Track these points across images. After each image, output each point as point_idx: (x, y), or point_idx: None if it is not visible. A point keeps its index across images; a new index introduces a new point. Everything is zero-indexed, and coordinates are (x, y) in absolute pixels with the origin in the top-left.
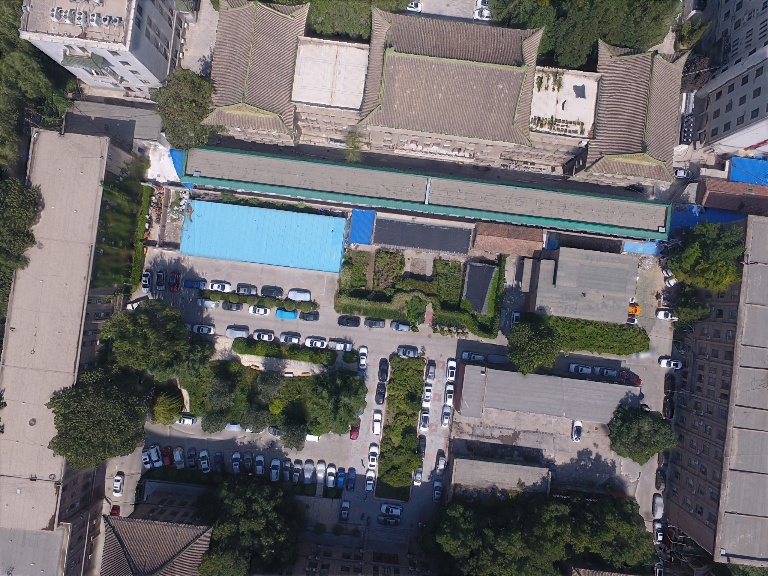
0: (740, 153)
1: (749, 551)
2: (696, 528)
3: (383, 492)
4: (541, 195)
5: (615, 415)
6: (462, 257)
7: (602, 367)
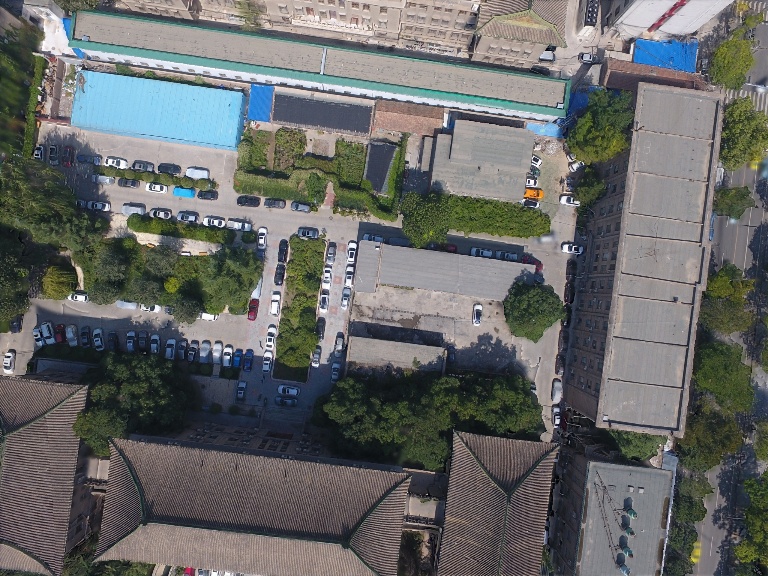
0: (644, 35)
1: (631, 418)
2: (585, 402)
3: (281, 373)
4: (439, 69)
5: (510, 292)
6: (365, 139)
7: (503, 251)
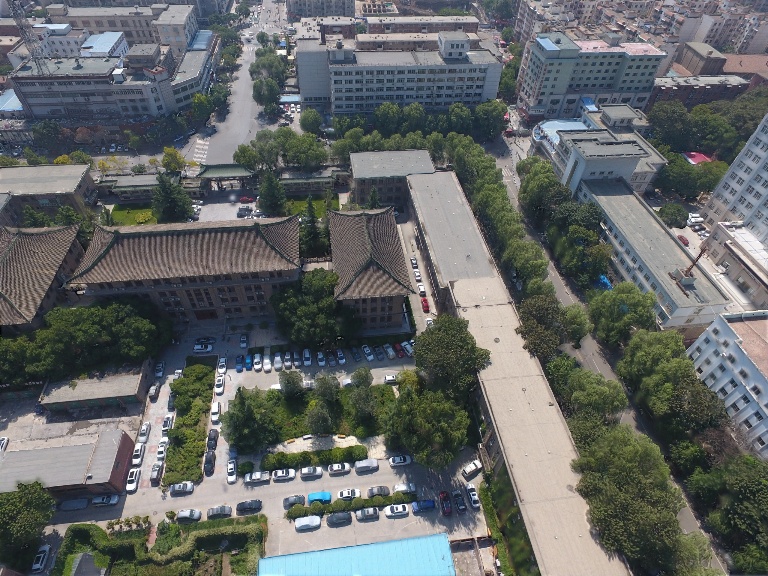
0: None
1: None
2: None
3: (211, 360)
4: None
5: None
6: None
7: None
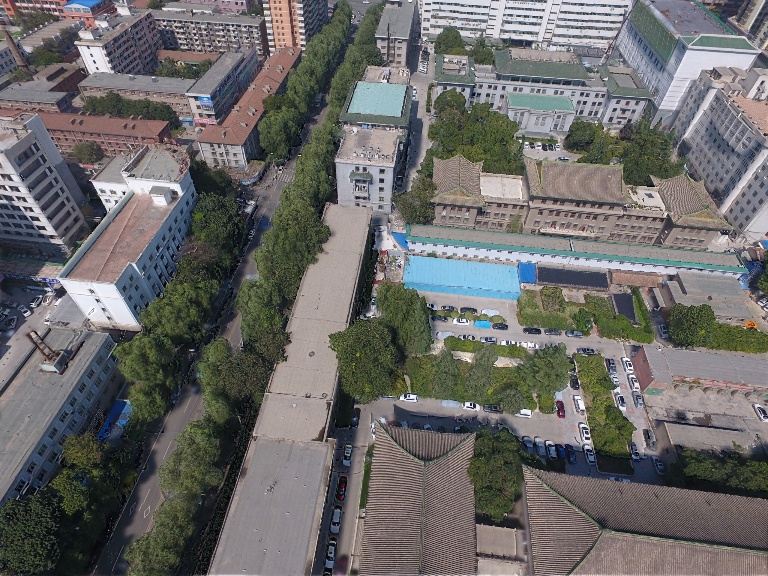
0: (764, 238)
1: None
2: None
3: (605, 467)
4: (648, 249)
5: None
6: (604, 294)
7: None
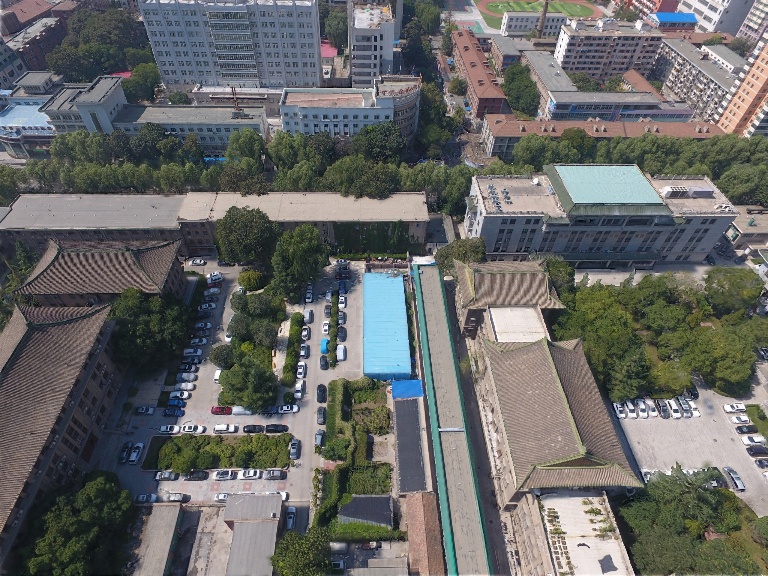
0: None
1: None
2: None
3: (156, 444)
4: (481, 556)
5: None
6: None
7: None
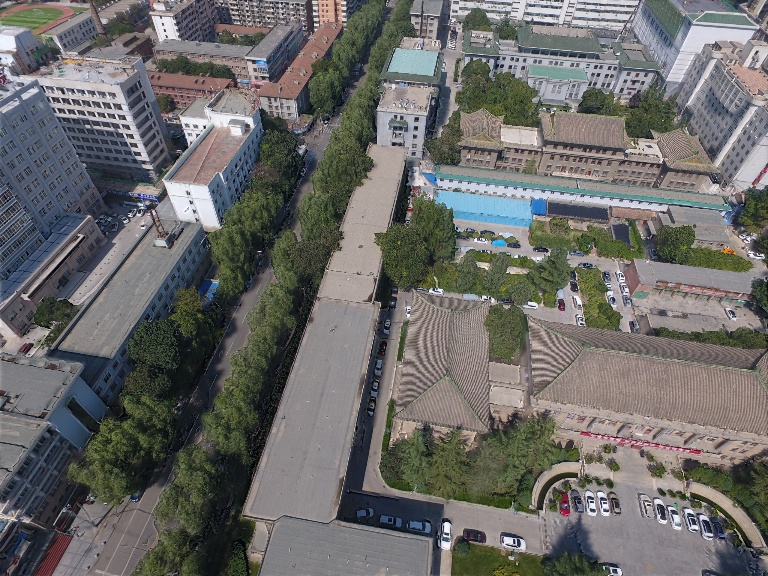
0: (751, 187)
1: None
2: None
3: None
4: (645, 190)
5: (753, 287)
6: (605, 226)
7: None
